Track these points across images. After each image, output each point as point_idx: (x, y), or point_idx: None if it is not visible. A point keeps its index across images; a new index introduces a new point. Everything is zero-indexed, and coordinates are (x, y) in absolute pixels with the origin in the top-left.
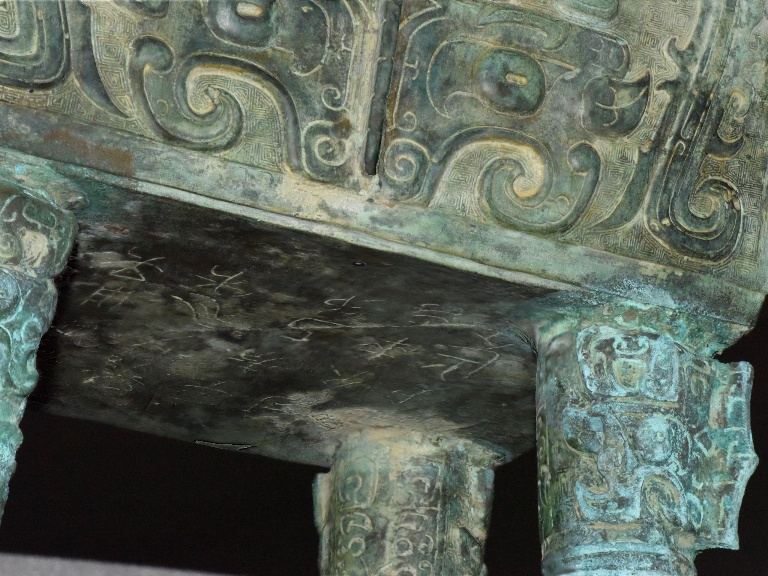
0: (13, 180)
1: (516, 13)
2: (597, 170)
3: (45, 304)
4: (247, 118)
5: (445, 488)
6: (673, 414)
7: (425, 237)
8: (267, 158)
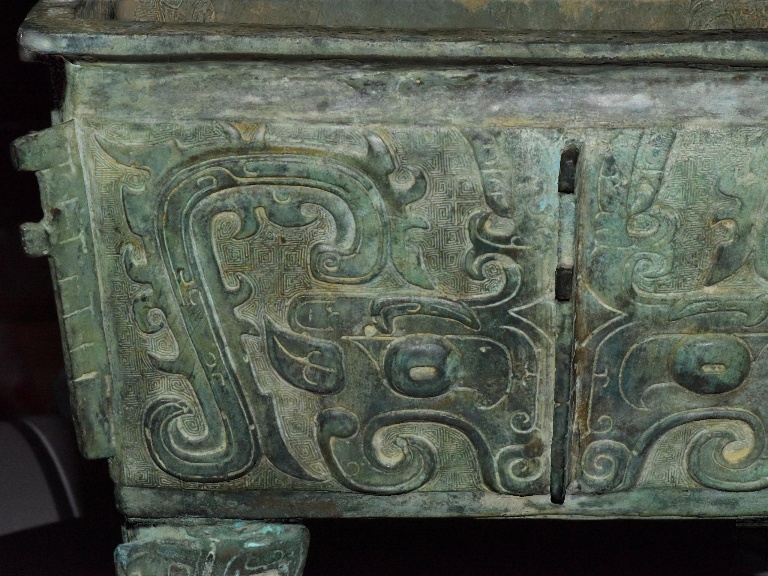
0: (235, 534)
1: (709, 304)
2: None
3: None
4: (440, 454)
5: None
6: None
7: (637, 508)
8: (465, 482)
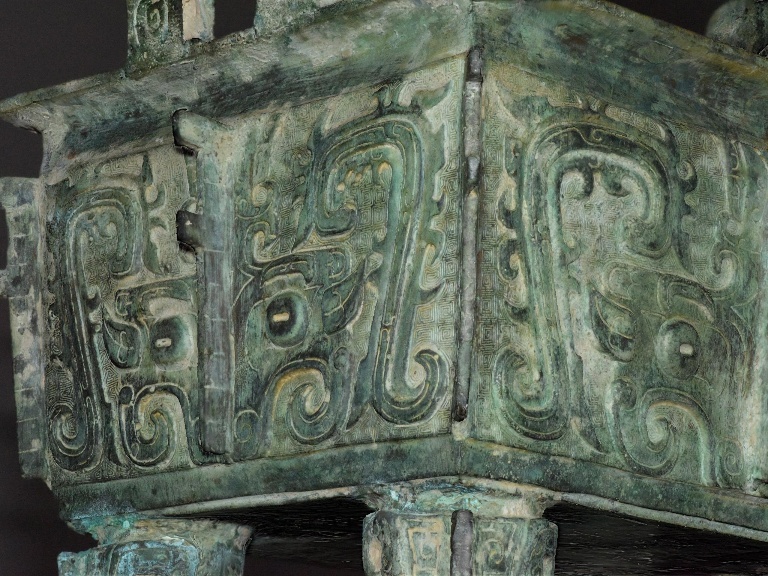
0: None
1: None
2: None
3: None
4: None
5: None
6: None
7: None
8: None
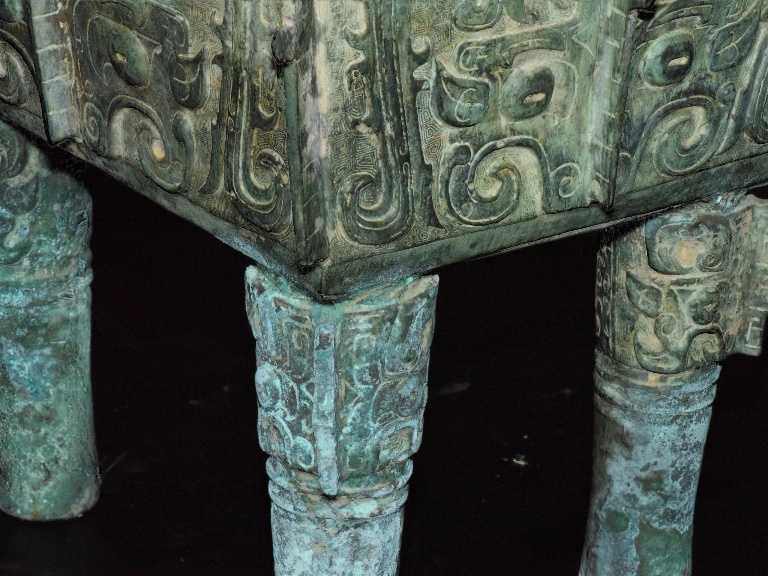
0: None
1: None
2: (185, 142)
3: (10, 198)
4: None
5: (616, 231)
6: (277, 366)
7: None
8: None
